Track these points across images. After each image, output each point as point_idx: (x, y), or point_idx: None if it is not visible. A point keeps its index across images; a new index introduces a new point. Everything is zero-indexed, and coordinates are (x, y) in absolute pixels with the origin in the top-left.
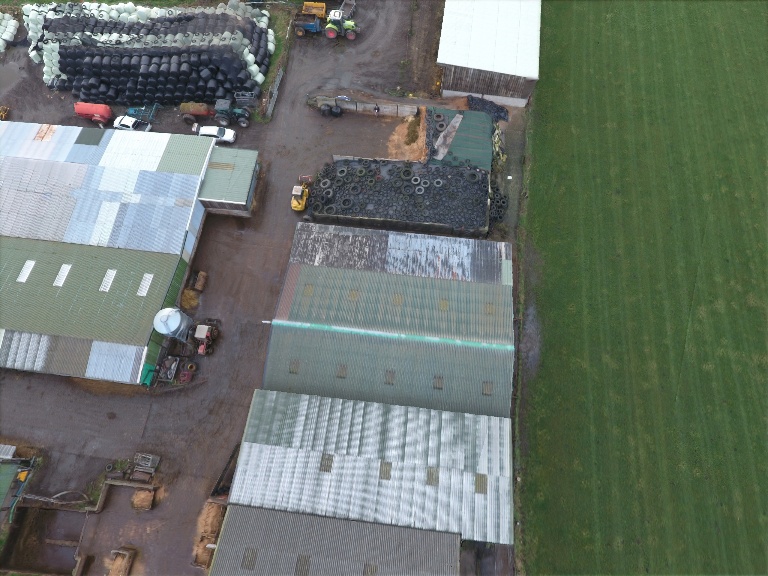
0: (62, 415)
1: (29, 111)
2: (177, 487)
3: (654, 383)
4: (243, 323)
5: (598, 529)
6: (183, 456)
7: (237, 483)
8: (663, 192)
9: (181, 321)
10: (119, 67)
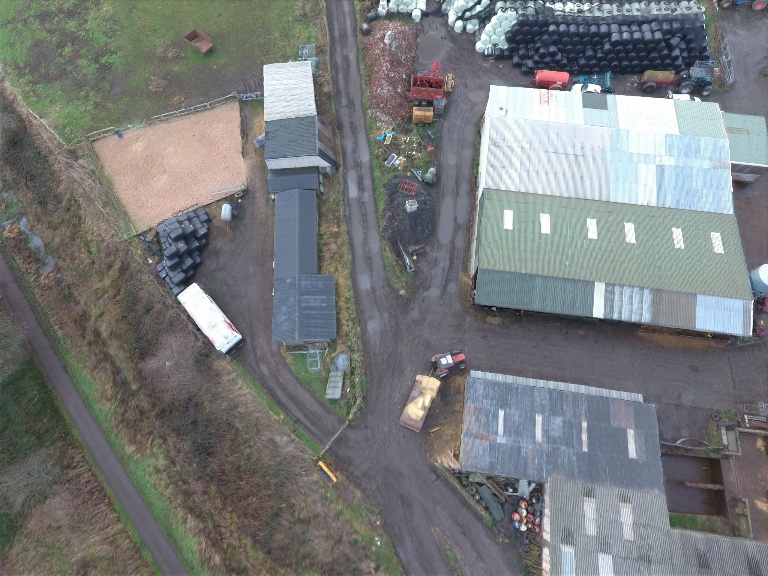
0: (643, 367)
1: (472, 79)
2: None
3: None
4: None
5: None
6: None
7: None
8: None
9: None
10: (585, 35)
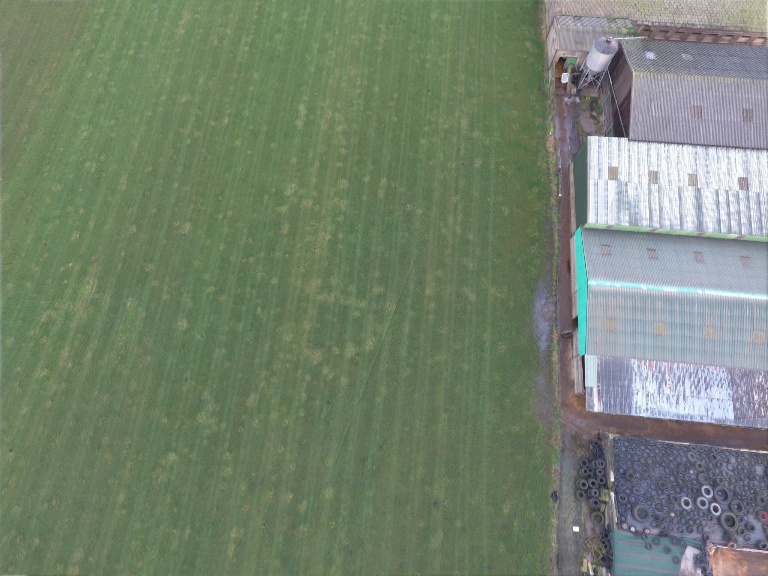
0: None
1: None
2: None
3: (431, 275)
4: None
5: (492, 171)
6: None
7: None
8: (380, 502)
9: None
10: None
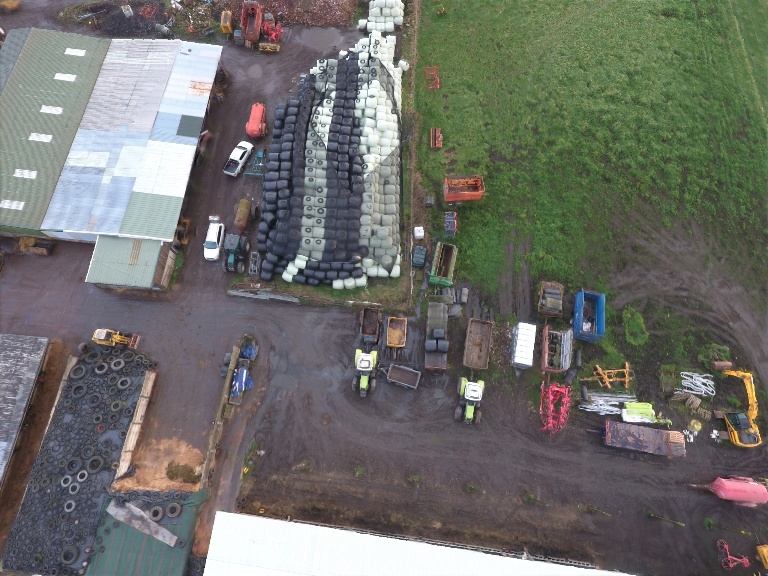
0: None
1: (276, 67)
2: None
3: None
4: None
5: None
6: None
7: None
8: None
9: None
10: None
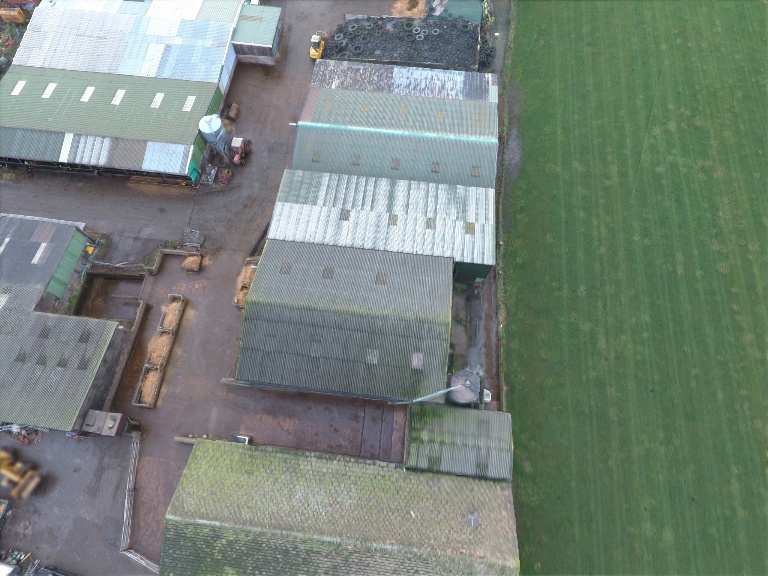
0: (120, 210)
1: None
2: (219, 257)
3: (615, 181)
4: (270, 143)
5: (566, 281)
6: (223, 237)
7: (273, 227)
8: (627, 44)
9: (221, 125)
10: None
